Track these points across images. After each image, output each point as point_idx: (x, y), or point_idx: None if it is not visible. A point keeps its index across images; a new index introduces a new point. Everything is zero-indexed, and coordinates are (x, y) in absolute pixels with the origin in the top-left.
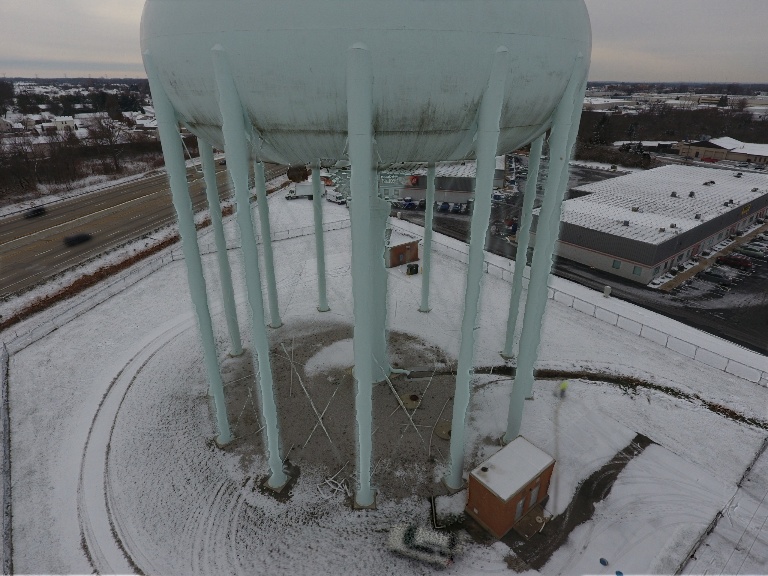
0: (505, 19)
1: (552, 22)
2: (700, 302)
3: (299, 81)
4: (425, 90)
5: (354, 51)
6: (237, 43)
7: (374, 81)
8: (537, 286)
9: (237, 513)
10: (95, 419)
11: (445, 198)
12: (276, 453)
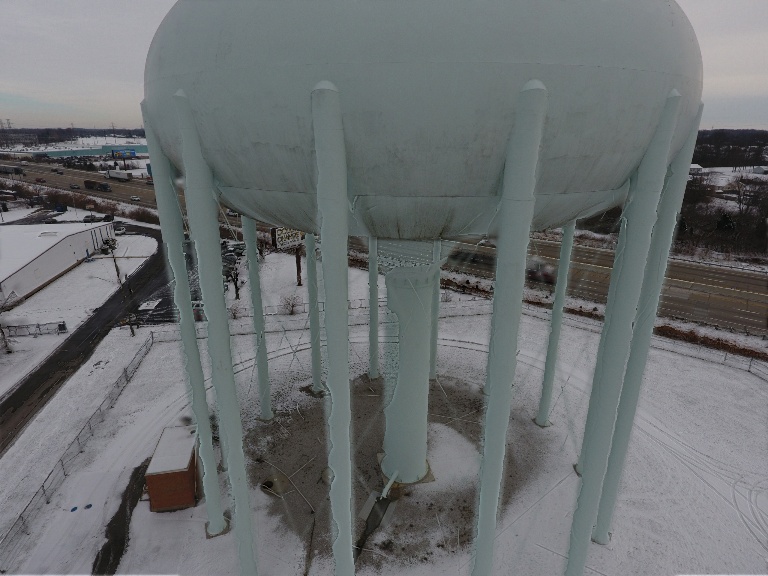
0: None
1: None
2: None
3: None
4: None
5: None
6: None
7: None
8: None
9: (309, 373)
10: None
11: None
12: None
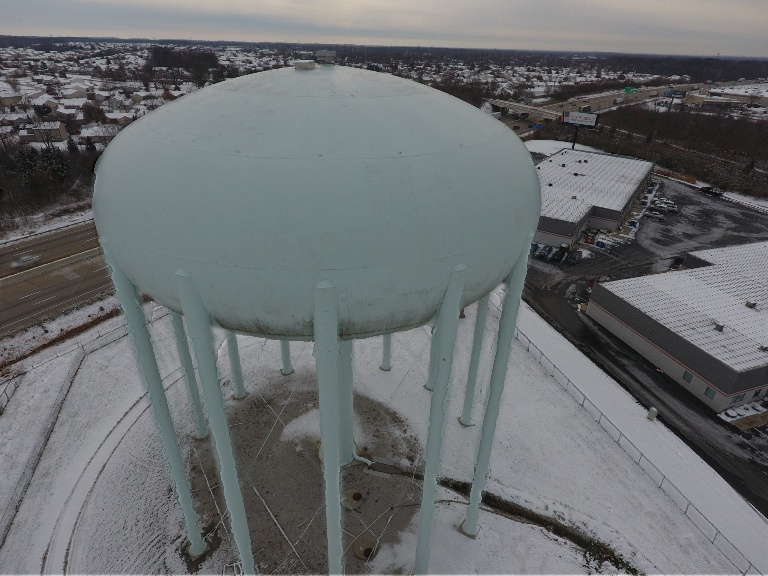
0: (328, 256)
1: (401, 249)
2: None
3: (149, 283)
4: (249, 310)
5: (176, 276)
6: (111, 241)
7: (202, 298)
8: (431, 463)
9: (153, 570)
10: (108, 436)
11: (536, 238)
12: (191, 530)
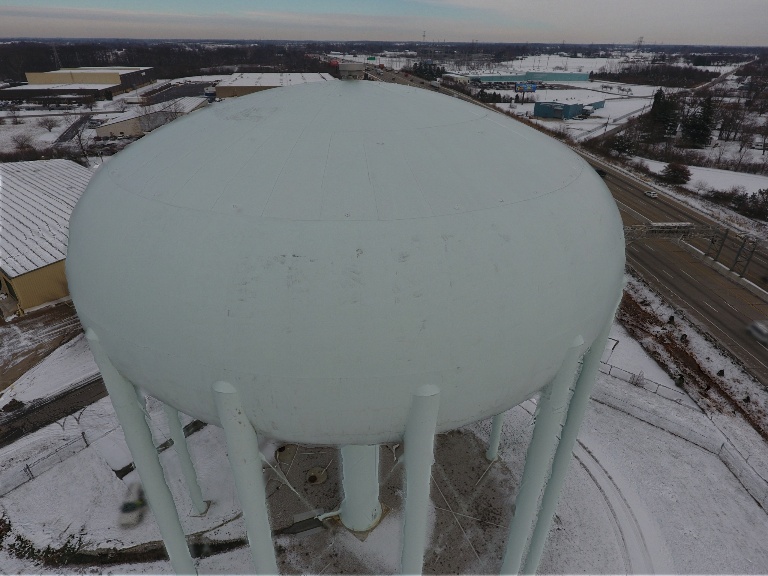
0: None
1: None
2: None
3: None
4: None
5: None
6: None
7: None
8: None
9: None
10: None
11: None
12: None
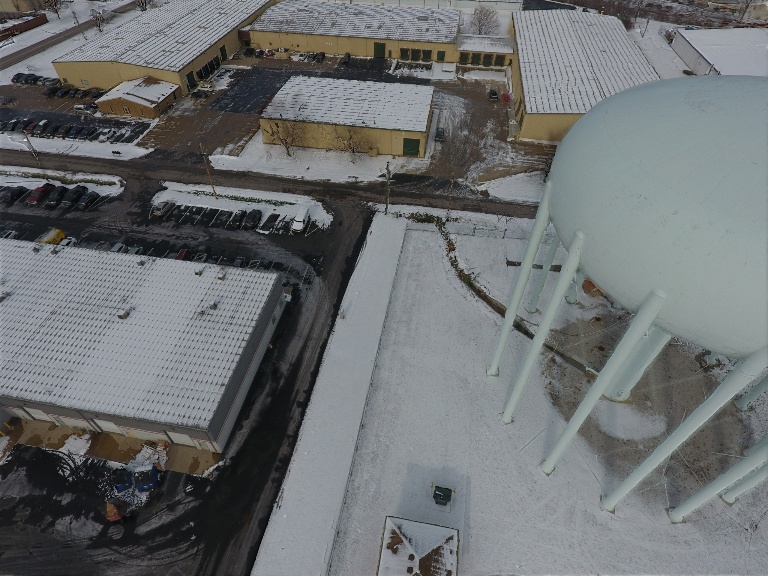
0: None
1: None
2: (301, 270)
3: None
4: None
5: None
6: None
7: None
8: None
9: None
10: None
11: None
12: None
